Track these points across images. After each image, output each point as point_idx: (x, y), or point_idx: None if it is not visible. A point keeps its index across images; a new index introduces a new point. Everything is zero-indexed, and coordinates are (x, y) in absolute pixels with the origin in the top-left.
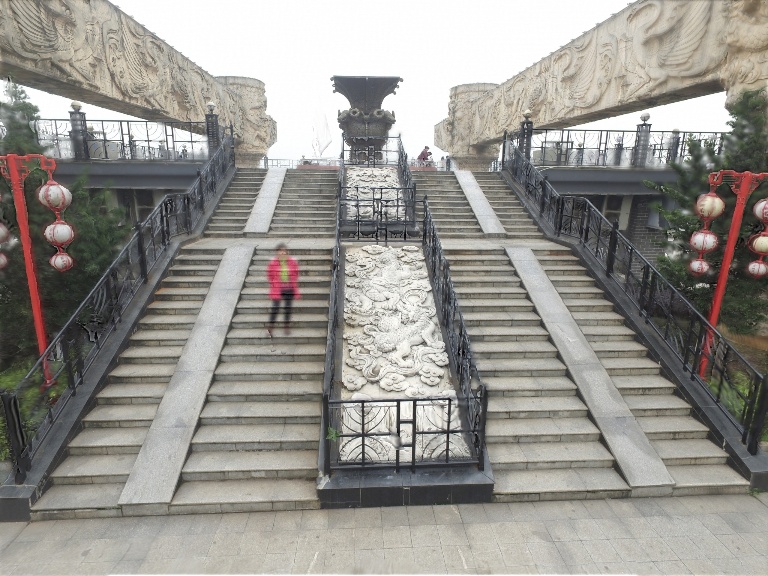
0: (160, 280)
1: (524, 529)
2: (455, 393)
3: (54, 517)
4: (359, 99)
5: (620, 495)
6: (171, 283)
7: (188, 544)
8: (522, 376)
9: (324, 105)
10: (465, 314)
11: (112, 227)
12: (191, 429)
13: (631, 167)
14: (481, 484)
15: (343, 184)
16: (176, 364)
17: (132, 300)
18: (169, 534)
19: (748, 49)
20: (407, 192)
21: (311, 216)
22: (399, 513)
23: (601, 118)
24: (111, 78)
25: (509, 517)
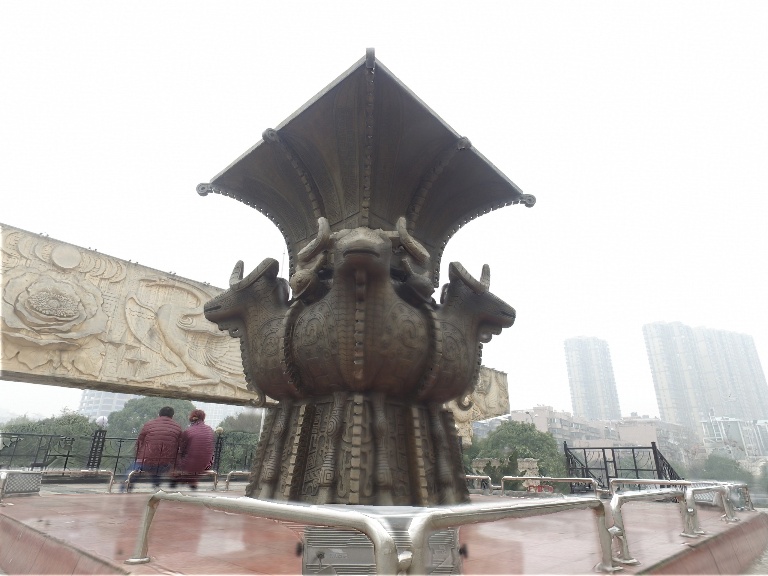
0: None
1: None
2: None
3: None
4: None
5: None
6: None
7: None
8: None
9: None
10: None
11: None
12: None
13: None
14: None
15: None
16: None
17: None
18: None
19: (457, 419)
20: None
21: None
22: None
23: (191, 399)
24: None
25: None
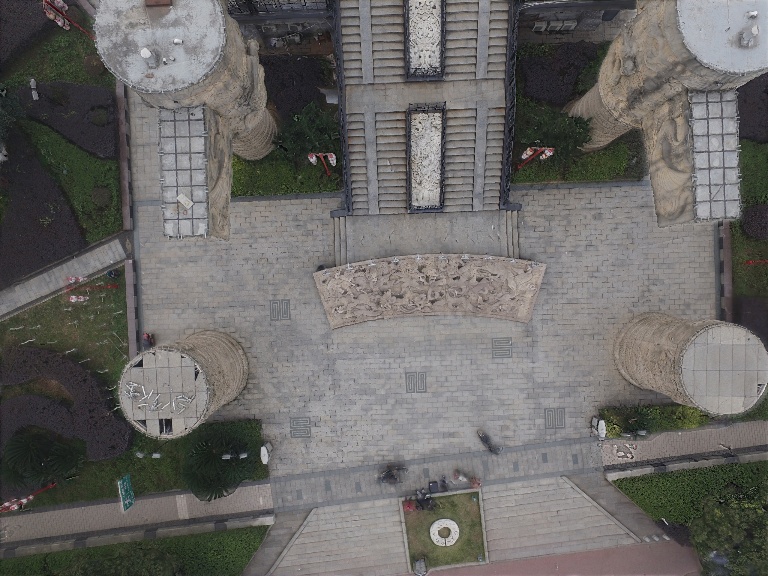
0: None
1: (447, 219)
2: (440, 189)
3: (357, 215)
4: None
5: (470, 211)
6: None
7: (385, 222)
8: (461, 177)
9: None
10: (451, 151)
11: None
12: None
13: None
14: None
15: None
16: (366, 175)
17: (345, 153)
18: (381, 219)
19: None
20: None
21: (391, 59)
22: (423, 215)
23: None
24: None
25: (445, 216)
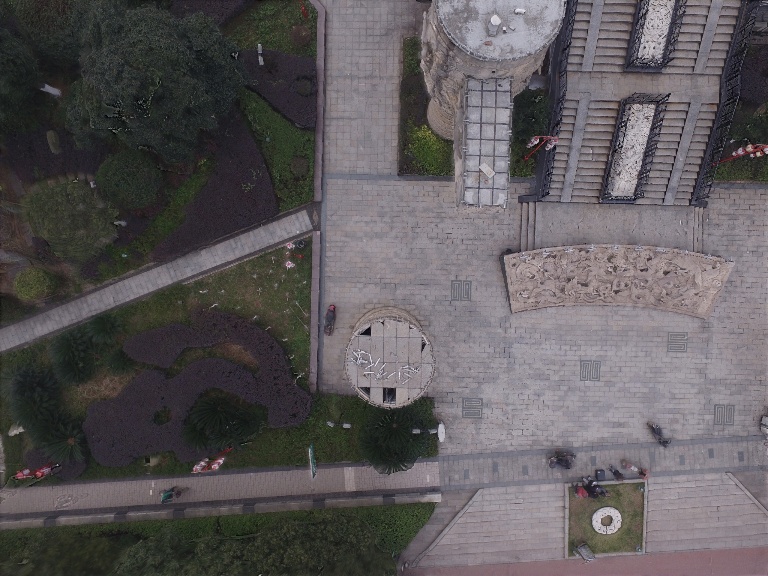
0: None
1: (636, 212)
2: (637, 181)
3: None
4: None
5: None
6: None
7: (575, 210)
8: (658, 170)
9: None
10: None
11: None
12: None
13: None
14: None
15: None
16: (566, 162)
17: None
18: (570, 207)
19: None
20: None
21: (614, 48)
22: (613, 206)
23: None
24: None
25: (634, 208)
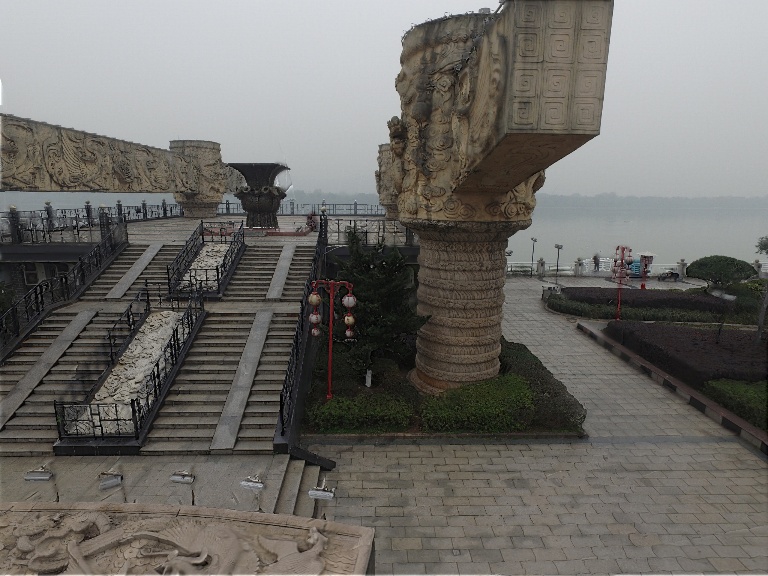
0: (28, 334)
1: None
2: (150, 402)
3: None
4: (252, 178)
5: (205, 453)
6: (36, 336)
7: None
8: (205, 394)
9: (285, 153)
10: (199, 357)
11: (4, 302)
12: (7, 418)
13: (402, 245)
14: (132, 446)
15: (192, 259)
16: None
17: (4, 348)
18: None
19: None
20: (229, 267)
21: None
22: (90, 458)
23: None
24: (50, 177)
25: (140, 461)
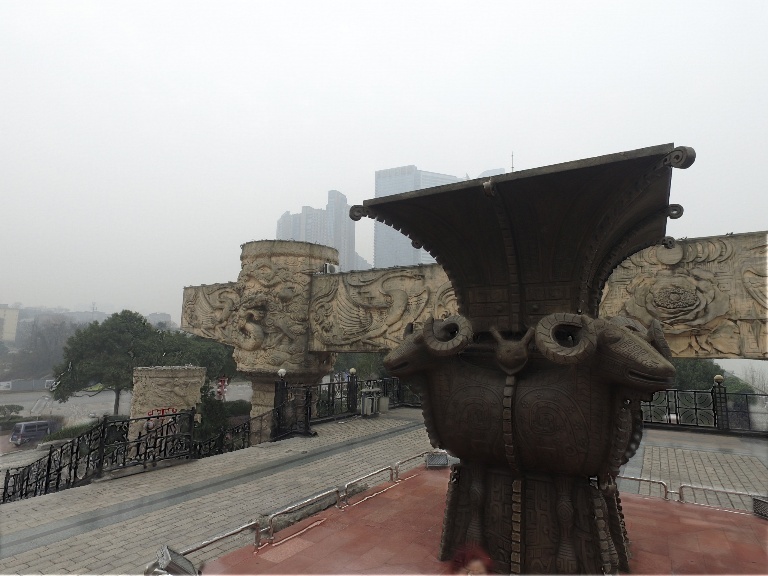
0: None
1: None
2: None
3: None
4: None
5: None
6: None
7: None
8: None
9: None
10: None
11: None
12: None
13: None
14: None
15: None
16: None
17: None
18: None
19: None
20: None
21: None
22: None
23: None
24: None
25: None
